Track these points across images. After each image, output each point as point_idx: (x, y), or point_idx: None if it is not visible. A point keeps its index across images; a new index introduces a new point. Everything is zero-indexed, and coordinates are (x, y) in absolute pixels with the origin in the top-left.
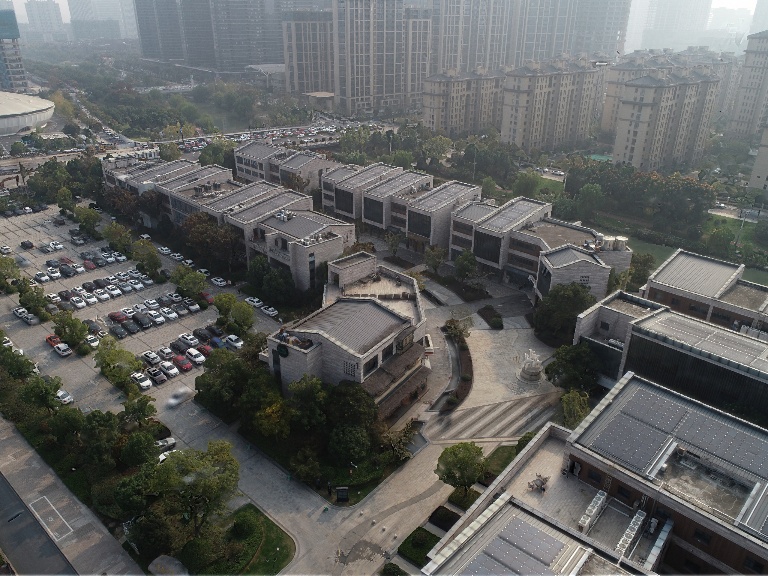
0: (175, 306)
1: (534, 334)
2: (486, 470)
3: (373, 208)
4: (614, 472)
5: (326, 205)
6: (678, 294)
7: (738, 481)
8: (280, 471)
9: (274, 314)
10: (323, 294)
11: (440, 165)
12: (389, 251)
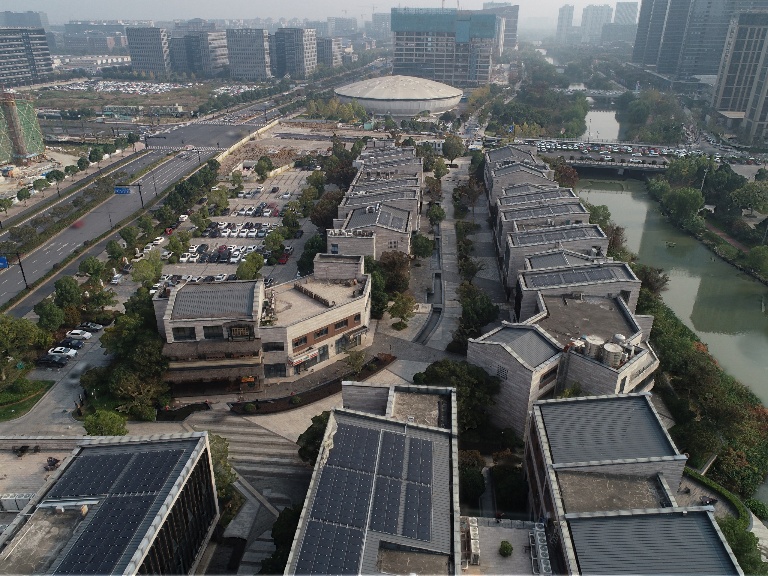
0: None
1: None
2: None
3: (501, 231)
4: None
5: None
6: None
7: None
8: None
9: None
10: None
11: (734, 218)
12: None
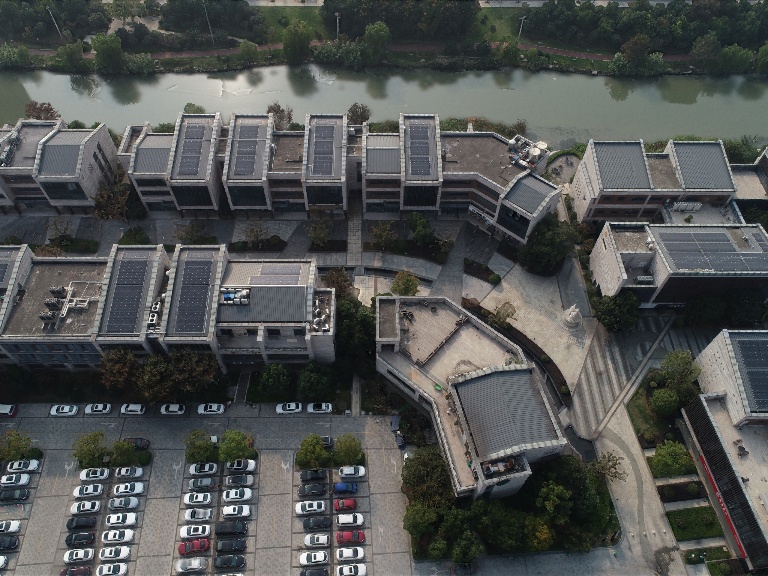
0: (235, 482)
1: (525, 270)
2: (651, 437)
3: (246, 194)
4: None
5: (150, 202)
6: (624, 194)
7: None
8: (556, 555)
9: (331, 409)
10: (395, 372)
11: (156, 35)
12: (318, 243)
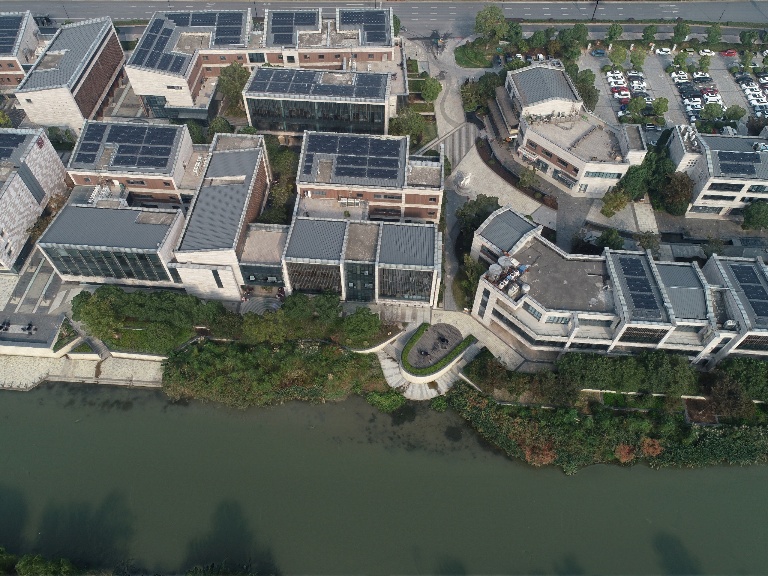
0: None
1: None
2: (429, 116)
3: None
4: None
5: None
6: None
7: None
8: None
9: (650, 143)
10: None
11: None
12: None
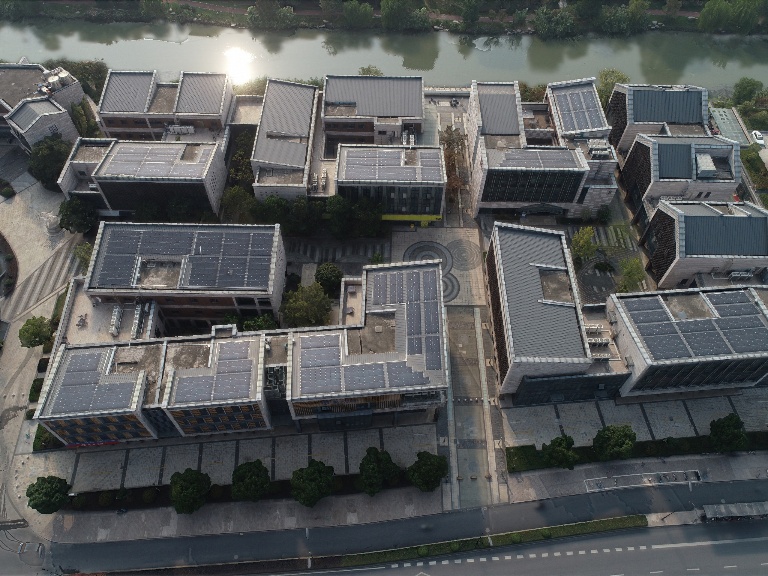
0: None
1: (43, 186)
2: (56, 320)
3: None
4: (116, 294)
5: None
6: (122, 117)
7: (176, 262)
8: None
9: None
10: None
11: None
12: None
